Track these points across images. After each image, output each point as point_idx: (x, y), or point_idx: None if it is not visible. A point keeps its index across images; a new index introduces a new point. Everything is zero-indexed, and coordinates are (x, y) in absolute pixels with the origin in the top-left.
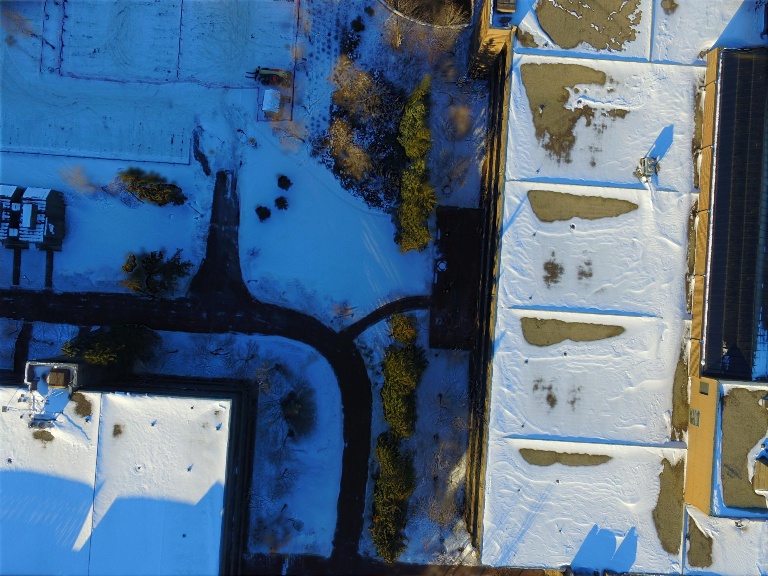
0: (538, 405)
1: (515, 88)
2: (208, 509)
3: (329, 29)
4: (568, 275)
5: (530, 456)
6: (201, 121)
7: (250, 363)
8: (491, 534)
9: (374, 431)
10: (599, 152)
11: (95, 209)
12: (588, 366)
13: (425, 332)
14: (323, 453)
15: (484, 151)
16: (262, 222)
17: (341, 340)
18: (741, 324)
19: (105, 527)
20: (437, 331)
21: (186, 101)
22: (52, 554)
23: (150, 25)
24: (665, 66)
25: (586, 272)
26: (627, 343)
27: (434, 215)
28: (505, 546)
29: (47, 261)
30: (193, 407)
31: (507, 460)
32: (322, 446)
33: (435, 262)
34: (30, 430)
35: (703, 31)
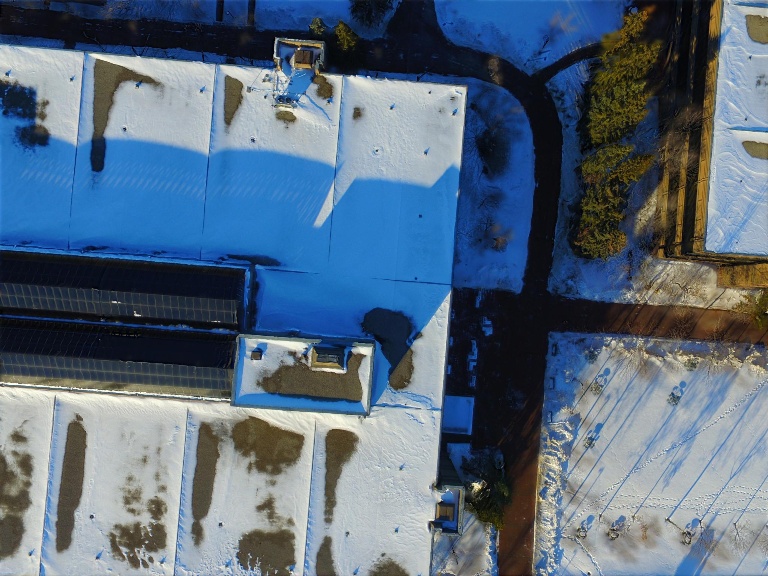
0: (760, 100)
1: None
2: (444, 191)
3: None
4: None
5: (752, 149)
6: None
7: None
8: (715, 221)
9: (564, 172)
10: None
11: None
12: None
13: None
14: (515, 191)
15: None
16: None
17: (533, 83)
18: None
19: (345, 205)
20: None
21: None
22: (294, 230)
23: None
24: None
25: None
26: None
27: None
28: (728, 233)
29: None
30: (430, 92)
31: (731, 151)
32: (515, 184)
33: (625, 9)
34: (273, 110)
35: None
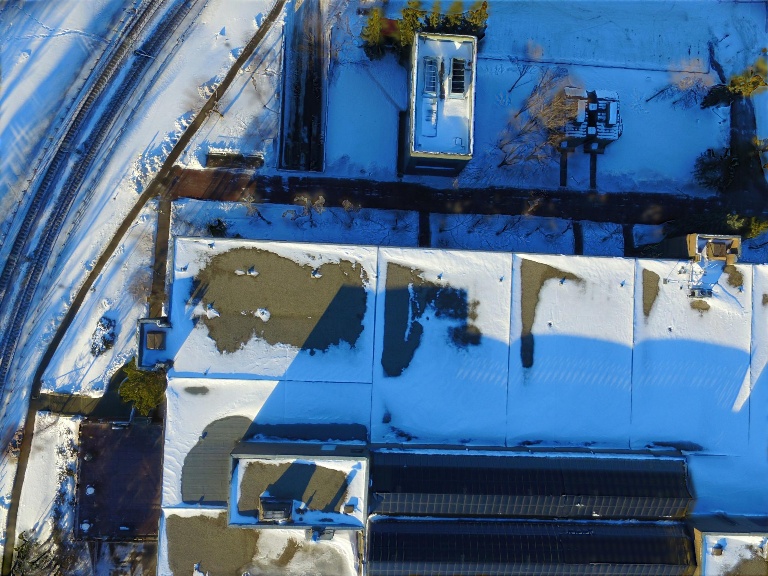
0: None
1: None
2: None
3: None
4: None
5: None
6: (715, 33)
7: None
8: None
9: None
10: None
11: (632, 114)
12: None
13: None
14: None
15: None
16: None
17: None
18: None
19: (760, 388)
20: None
21: (700, 14)
22: (714, 415)
23: None
24: None
25: None
26: None
27: None
28: None
29: (591, 163)
30: None
31: None
32: None
33: None
34: (688, 300)
35: None
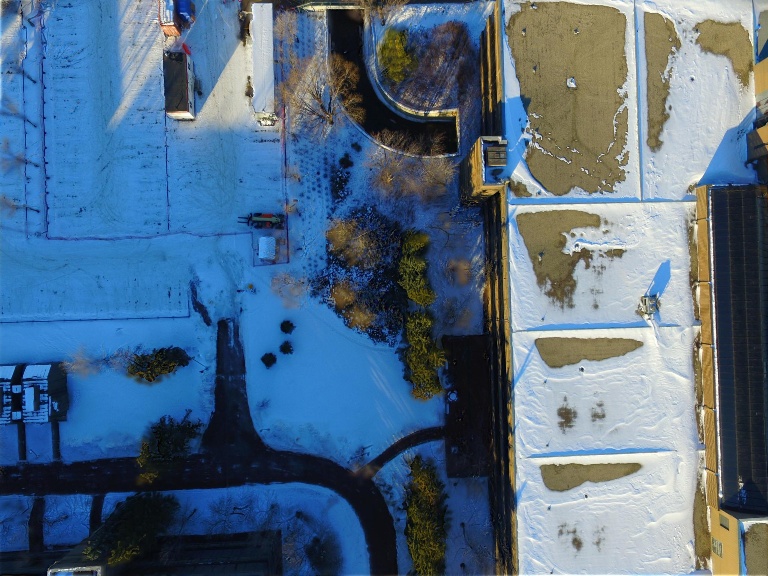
0: (564, 550)
1: (513, 239)
2: None
3: (318, 168)
4: (582, 418)
5: None
6: (197, 271)
7: (270, 514)
8: None
9: (401, 567)
10: (601, 294)
11: (97, 374)
12: (609, 505)
13: (442, 463)
14: None
15: (484, 279)
16: (269, 369)
17: (359, 480)
18: (754, 459)
19: None
20: (454, 460)
21: (180, 252)
22: None
23: (135, 179)
24: (656, 204)
25: (599, 414)
26: (645, 479)
27: (440, 345)
28: None
29: (53, 432)
30: None
31: None
32: None
33: (445, 392)
34: None
35: (690, 166)
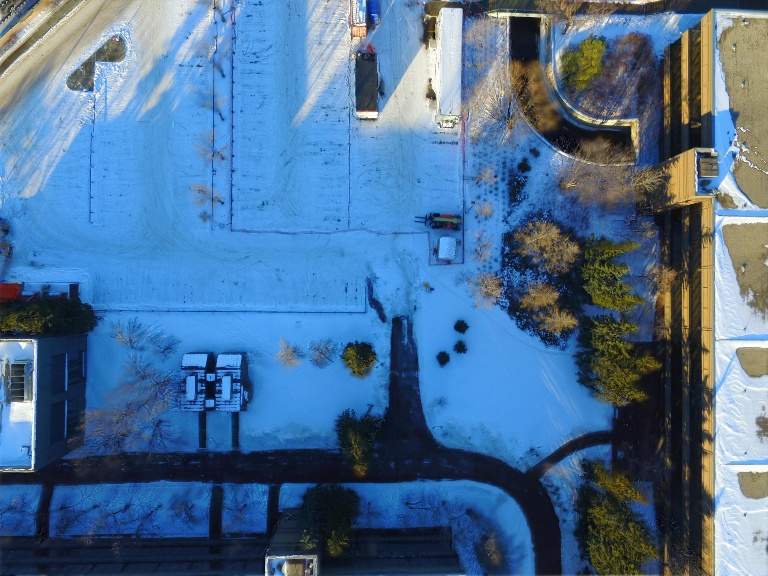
0: (758, 557)
1: (719, 249)
2: None
3: (496, 172)
4: None
5: None
6: (374, 268)
7: (441, 510)
8: None
9: (565, 568)
10: None
11: (277, 366)
12: None
13: None
14: None
15: (657, 287)
16: (442, 367)
17: (527, 480)
18: None
19: None
20: (620, 464)
21: (357, 249)
22: None
23: (317, 175)
24: None
25: None
26: None
27: None
28: None
29: (233, 421)
30: None
31: None
32: None
33: None
34: None
35: None
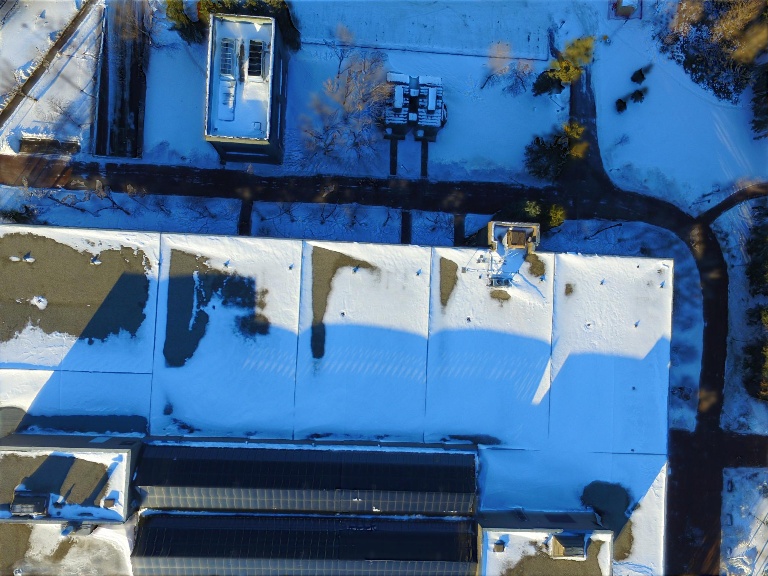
0: None
1: None
2: (655, 362)
3: None
4: None
5: None
6: (555, 20)
7: (618, 247)
8: None
9: (732, 311)
10: None
11: (465, 102)
12: None
13: None
14: (686, 332)
15: None
16: (619, 114)
17: (698, 225)
18: None
19: (561, 381)
20: None
21: (540, 1)
22: (513, 407)
23: None
24: None
25: None
26: None
27: None
28: None
29: (422, 151)
30: (639, 266)
31: None
32: (685, 325)
33: None
34: (488, 290)
35: None
